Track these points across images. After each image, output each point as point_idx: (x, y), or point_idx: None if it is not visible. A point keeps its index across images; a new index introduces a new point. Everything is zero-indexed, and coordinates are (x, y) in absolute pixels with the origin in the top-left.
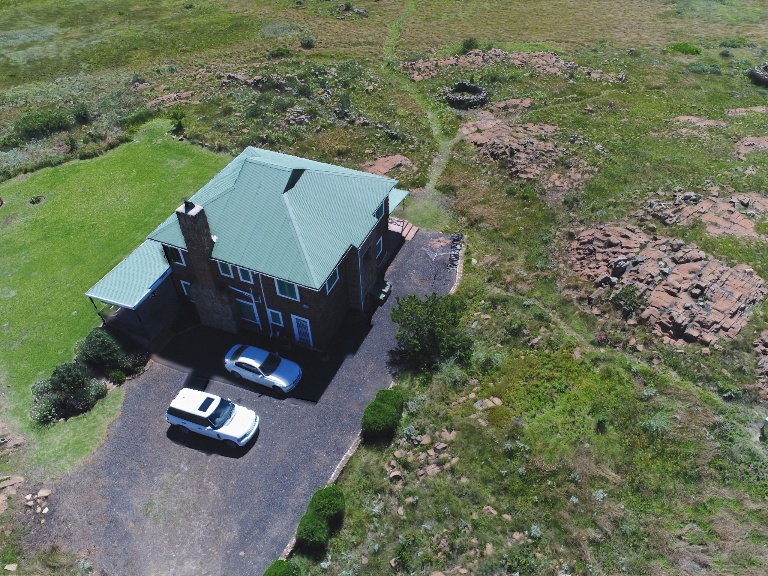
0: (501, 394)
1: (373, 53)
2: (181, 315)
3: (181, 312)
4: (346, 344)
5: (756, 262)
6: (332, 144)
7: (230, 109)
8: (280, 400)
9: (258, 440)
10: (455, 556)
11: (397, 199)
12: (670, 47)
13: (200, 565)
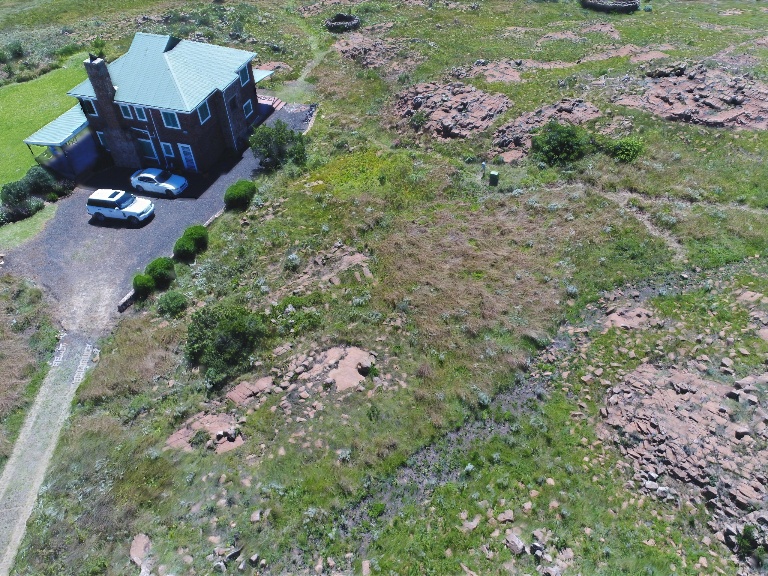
0: (323, 178)
1: (275, 3)
2: (99, 160)
3: (99, 158)
4: (222, 168)
5: (511, 92)
6: None
7: None
8: (171, 200)
9: (154, 219)
10: (275, 249)
11: (263, 75)
12: None
13: (110, 275)
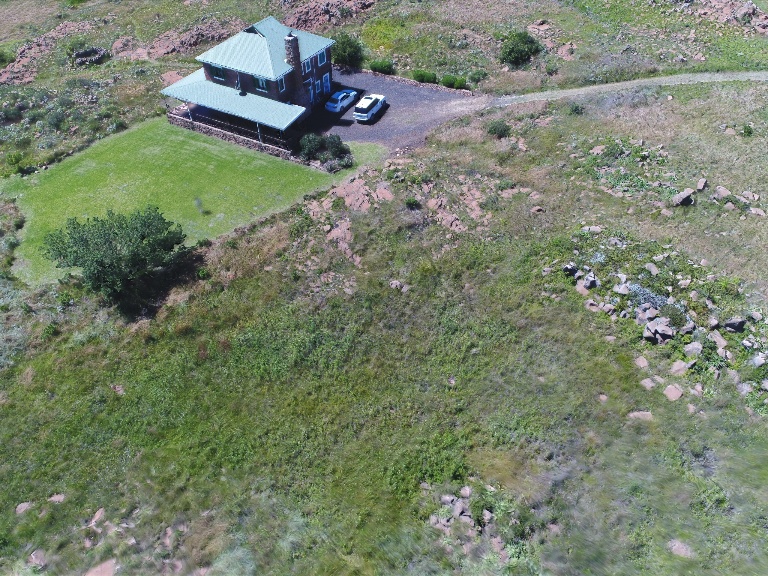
0: (379, 45)
1: None
2: (291, 127)
3: None
4: None
5: None
6: (135, 90)
7: (24, 139)
8: (360, 99)
9: None
10: None
11: None
12: (68, 6)
13: None
